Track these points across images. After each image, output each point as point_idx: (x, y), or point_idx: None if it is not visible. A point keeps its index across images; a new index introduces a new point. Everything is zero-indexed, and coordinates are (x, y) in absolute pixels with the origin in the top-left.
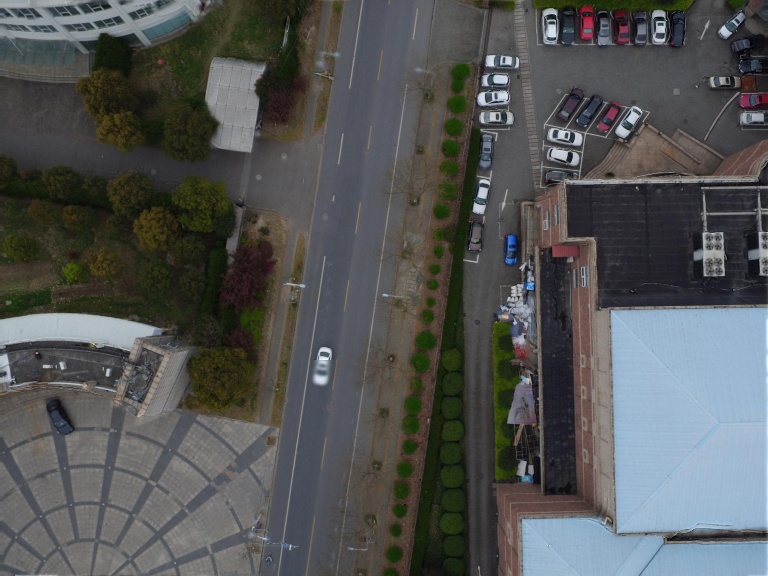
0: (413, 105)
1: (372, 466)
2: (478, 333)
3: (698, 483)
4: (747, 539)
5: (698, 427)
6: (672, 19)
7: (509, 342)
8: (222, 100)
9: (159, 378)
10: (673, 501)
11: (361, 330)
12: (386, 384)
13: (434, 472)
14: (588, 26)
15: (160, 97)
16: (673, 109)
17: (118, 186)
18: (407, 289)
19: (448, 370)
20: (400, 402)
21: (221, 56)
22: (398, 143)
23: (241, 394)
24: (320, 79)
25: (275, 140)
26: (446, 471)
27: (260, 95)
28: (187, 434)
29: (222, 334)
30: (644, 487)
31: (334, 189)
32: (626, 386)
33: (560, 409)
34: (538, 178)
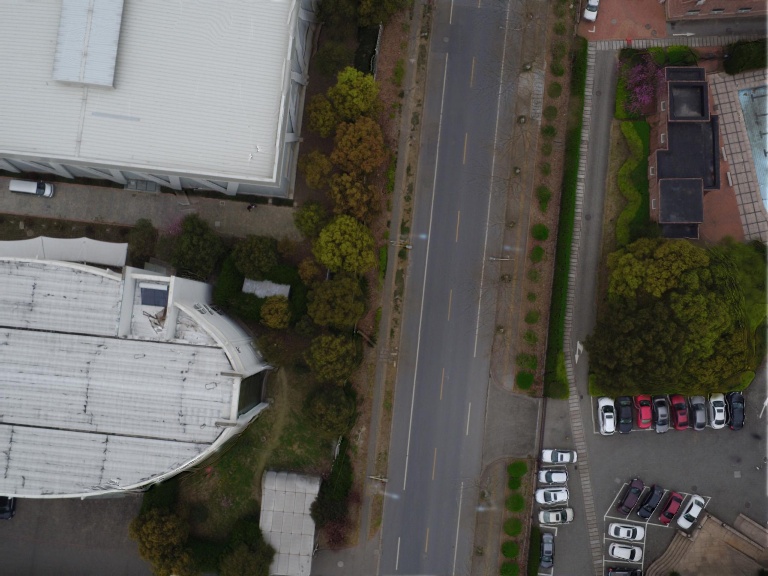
0: (470, 503)
1: None
2: None
3: None
4: None
5: None
6: (731, 402)
7: None
8: (277, 527)
9: None
10: None
11: None
12: None
13: None
14: (646, 417)
15: (210, 514)
16: (735, 493)
17: None
18: None
19: None
20: None
21: (271, 467)
22: (456, 544)
23: None
24: (373, 482)
25: (331, 553)
26: None
27: None
28: None
29: None
30: None
31: None
32: None
33: None
34: (600, 573)
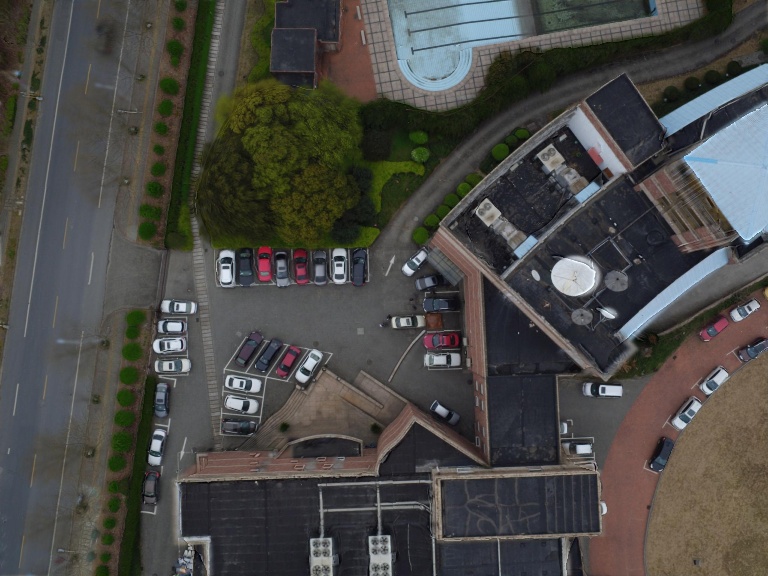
0: (90, 352)
1: None
2: None
3: None
4: None
5: None
6: (353, 258)
7: None
8: None
9: None
10: None
11: None
12: None
13: None
14: (264, 269)
15: None
16: (357, 349)
17: None
18: (83, 544)
19: None
20: None
21: None
22: (74, 392)
23: None
24: None
25: None
26: None
27: None
28: None
29: None
30: None
31: (9, 441)
32: None
33: None
34: (217, 425)
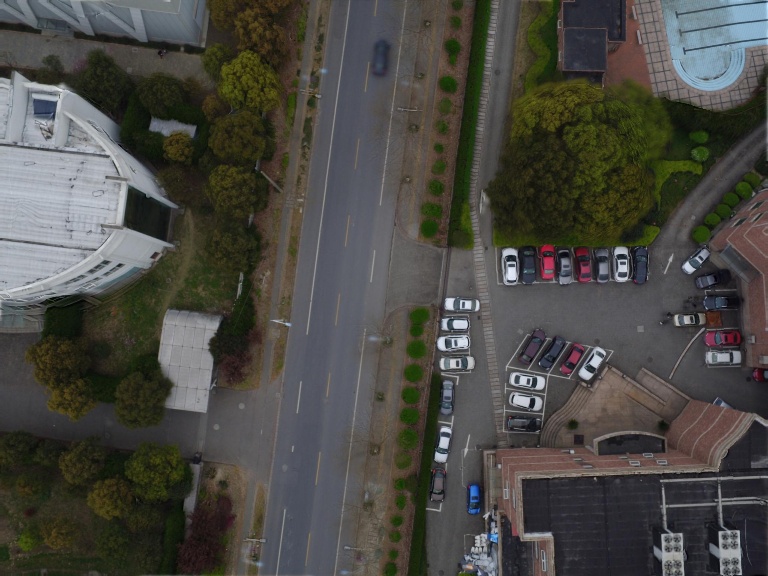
0: (372, 350)
1: None
2: None
3: None
4: None
5: None
6: (635, 256)
7: None
8: (175, 361)
9: None
10: None
11: None
12: None
13: None
14: (549, 267)
15: (113, 351)
16: (637, 347)
17: (69, 463)
18: (369, 541)
19: None
20: None
21: (175, 307)
22: (357, 390)
23: None
24: (277, 326)
25: (232, 393)
26: None
27: (214, 357)
28: None
29: None
30: None
31: (293, 439)
32: None
33: None
34: (501, 422)
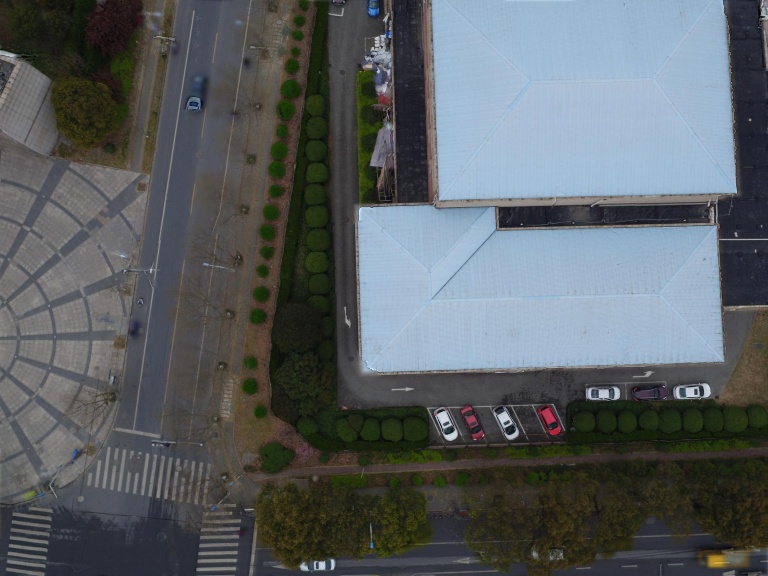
0: None
1: (240, 210)
2: (343, 82)
3: (514, 145)
4: (576, 222)
5: (511, 87)
6: None
7: (372, 88)
8: None
9: (11, 84)
10: (491, 164)
11: (229, 80)
12: (253, 132)
13: (299, 213)
14: None
15: None
16: None
17: None
18: (274, 41)
19: (312, 114)
20: (267, 149)
21: None
22: None
23: (111, 139)
24: None
25: None
26: (310, 211)
27: None
28: (60, 181)
29: (87, 72)
30: (463, 152)
31: None
32: (446, 58)
33: (413, 136)
34: None
